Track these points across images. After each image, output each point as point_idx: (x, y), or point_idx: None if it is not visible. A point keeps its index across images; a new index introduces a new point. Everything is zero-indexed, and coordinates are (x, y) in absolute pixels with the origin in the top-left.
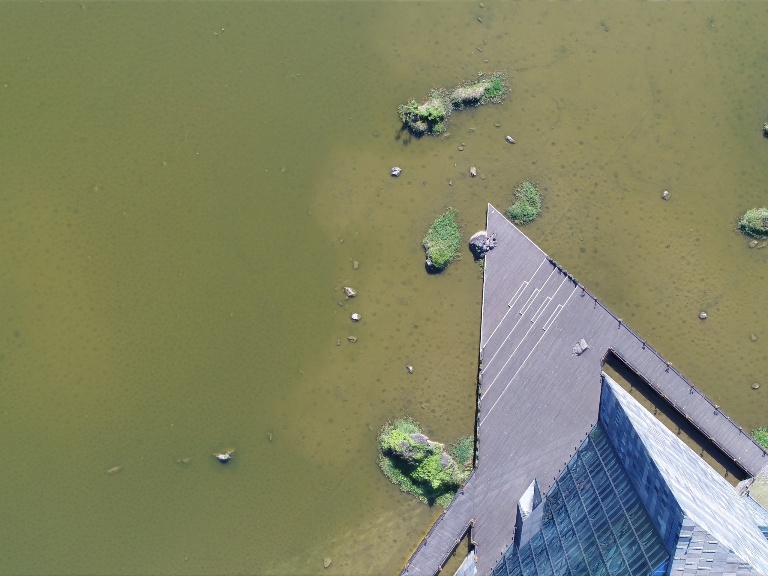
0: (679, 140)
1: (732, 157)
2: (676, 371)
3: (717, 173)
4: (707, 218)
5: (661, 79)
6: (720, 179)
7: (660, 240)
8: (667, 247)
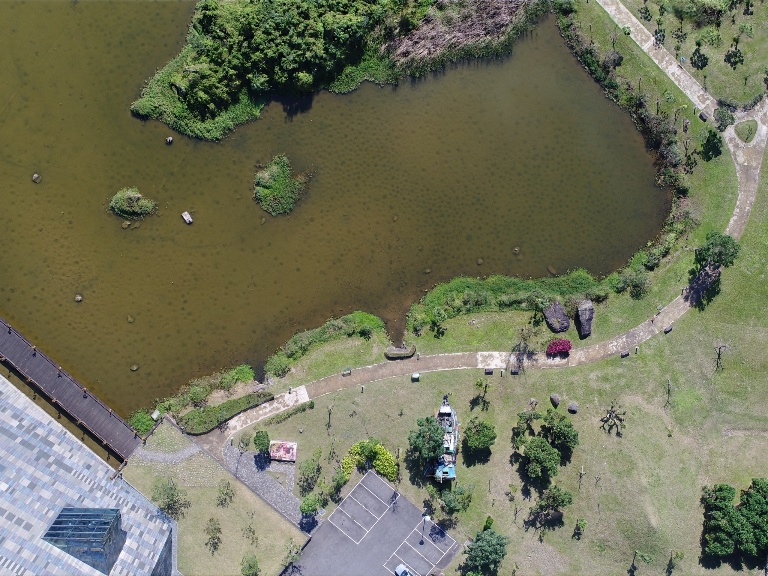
0: (48, 122)
1: (102, 138)
2: (43, 355)
3: (87, 154)
4: (79, 200)
5: (28, 62)
6: (90, 160)
7: (33, 224)
8: (40, 230)
